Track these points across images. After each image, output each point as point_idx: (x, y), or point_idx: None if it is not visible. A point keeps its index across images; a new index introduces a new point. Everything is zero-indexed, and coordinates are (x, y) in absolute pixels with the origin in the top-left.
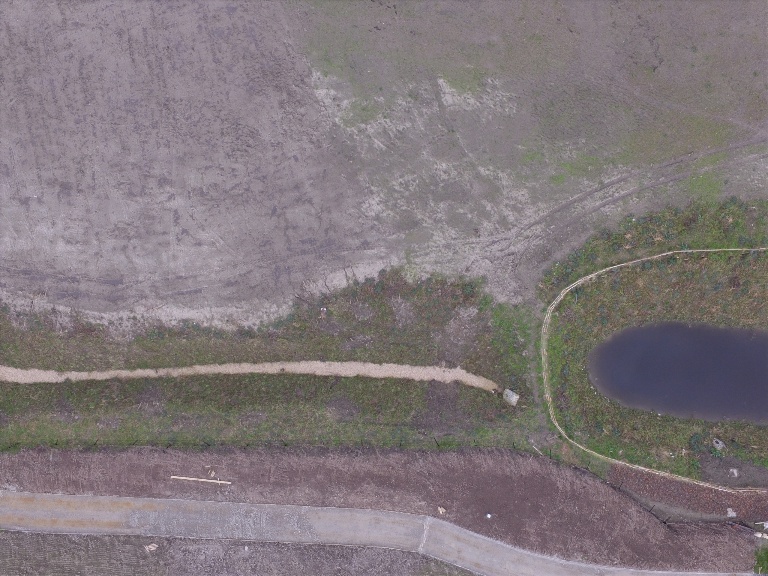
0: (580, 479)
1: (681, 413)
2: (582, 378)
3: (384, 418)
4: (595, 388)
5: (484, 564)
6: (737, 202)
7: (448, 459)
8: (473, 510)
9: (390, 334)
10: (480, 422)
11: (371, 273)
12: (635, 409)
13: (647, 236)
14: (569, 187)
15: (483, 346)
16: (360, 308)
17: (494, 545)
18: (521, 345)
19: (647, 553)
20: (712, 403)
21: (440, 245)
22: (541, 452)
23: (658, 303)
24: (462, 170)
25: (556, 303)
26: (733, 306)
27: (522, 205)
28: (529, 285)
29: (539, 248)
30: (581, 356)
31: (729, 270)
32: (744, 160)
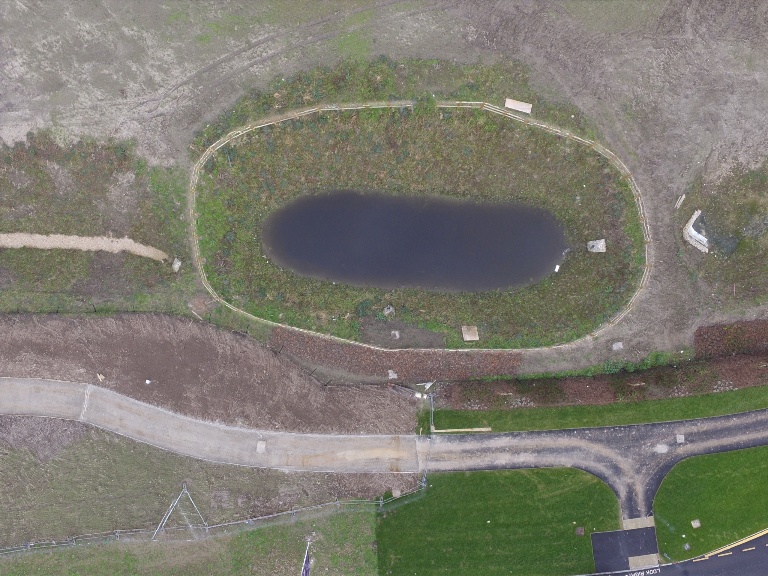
0: (240, 343)
1: (356, 281)
2: (253, 247)
3: (43, 286)
4: (268, 257)
5: (146, 431)
6: (387, 61)
7: (107, 326)
8: (133, 377)
9: (52, 203)
10: (139, 288)
11: (18, 136)
12: (309, 278)
13: (296, 95)
14: (215, 47)
15: (145, 213)
16: (17, 176)
17: (156, 412)
18: (178, 209)
19: (309, 417)
20: (389, 272)
21: (86, 107)
22: (201, 317)
23: (323, 168)
24: (105, 30)
25: (199, 161)
26: (399, 171)
27: (168, 65)
28: (181, 147)
29: (188, 109)
30: (252, 225)
31: (382, 130)
32: (391, 18)
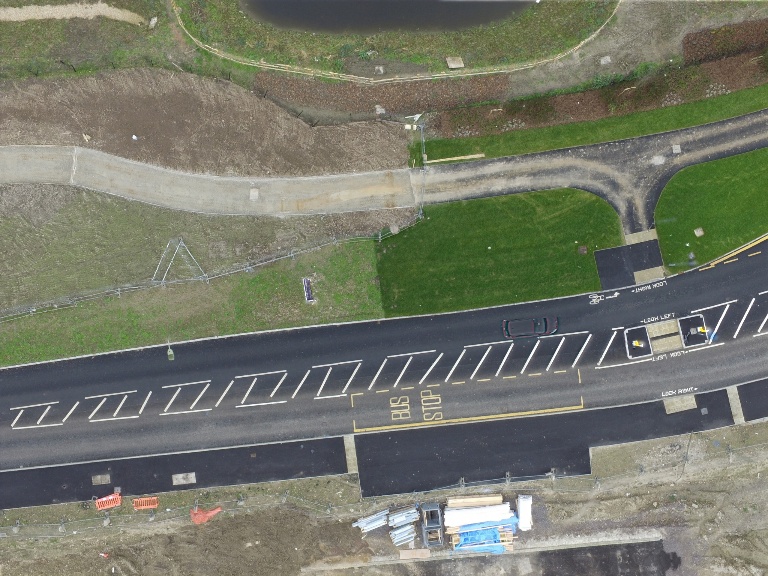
0: (223, 91)
1: (337, 31)
2: (228, 2)
3: (20, 52)
4: (245, 13)
5: (138, 190)
6: None
7: (88, 86)
8: (119, 135)
9: None
10: (117, 45)
11: None
12: (288, 30)
13: None
14: None
15: None
16: None
17: (146, 169)
18: None
19: (299, 159)
20: (369, 19)
21: None
22: (181, 68)
23: None
24: None
25: None
26: None
27: None
28: None
29: None
30: None
31: None
32: None
